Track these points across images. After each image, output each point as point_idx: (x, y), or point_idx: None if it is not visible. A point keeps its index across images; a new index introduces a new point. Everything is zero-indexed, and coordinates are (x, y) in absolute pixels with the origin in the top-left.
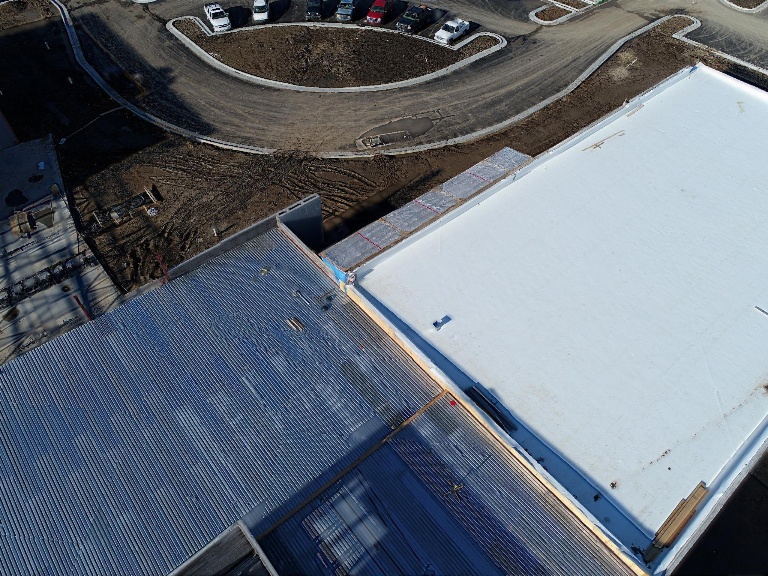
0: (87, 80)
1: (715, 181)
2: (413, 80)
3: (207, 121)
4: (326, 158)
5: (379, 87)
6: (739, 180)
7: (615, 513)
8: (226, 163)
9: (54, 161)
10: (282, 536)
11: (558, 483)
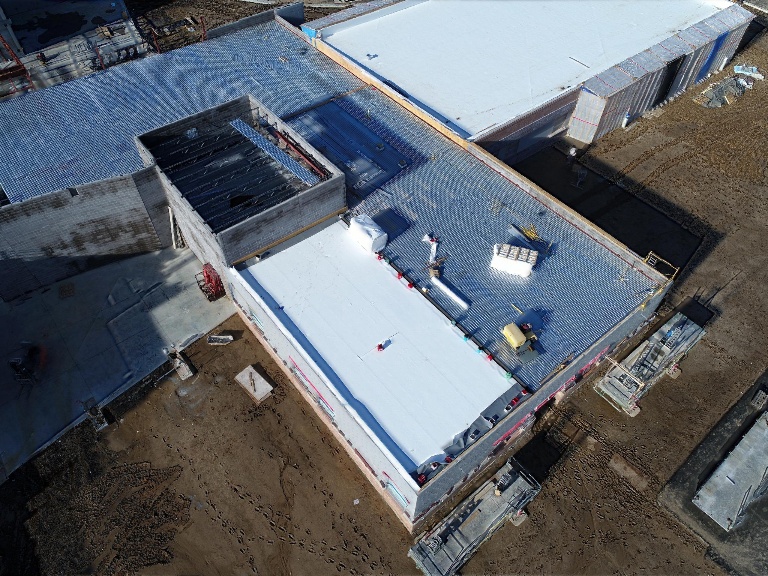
0: None
1: (567, 3)
2: None
3: None
4: (312, 7)
5: None
6: (584, 3)
7: (456, 127)
8: (241, 7)
9: (122, 3)
10: (271, 128)
11: (425, 111)
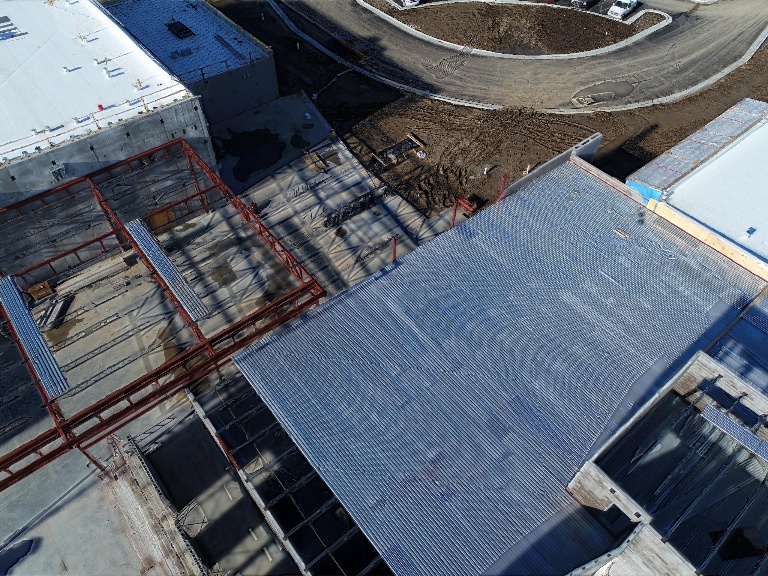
0: (308, 47)
1: None
2: (601, 50)
3: (432, 82)
4: (551, 113)
5: (573, 55)
6: None
7: None
8: (466, 116)
9: (317, 112)
10: None
11: None
